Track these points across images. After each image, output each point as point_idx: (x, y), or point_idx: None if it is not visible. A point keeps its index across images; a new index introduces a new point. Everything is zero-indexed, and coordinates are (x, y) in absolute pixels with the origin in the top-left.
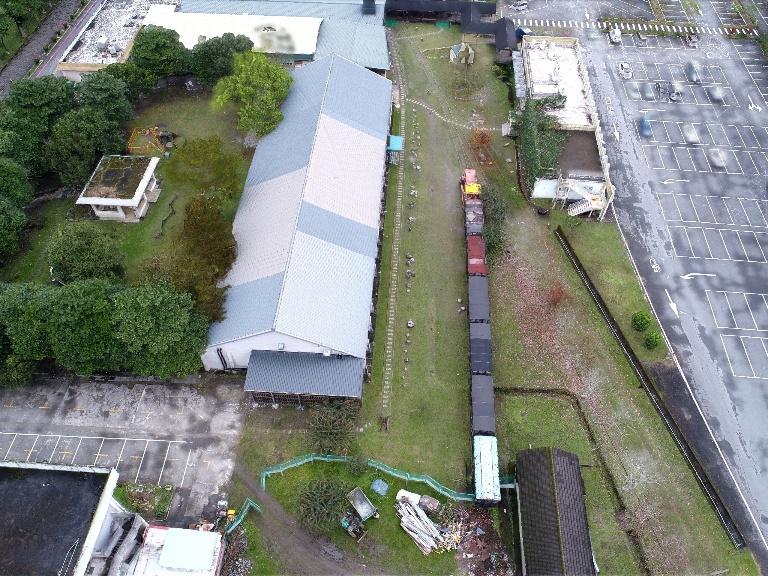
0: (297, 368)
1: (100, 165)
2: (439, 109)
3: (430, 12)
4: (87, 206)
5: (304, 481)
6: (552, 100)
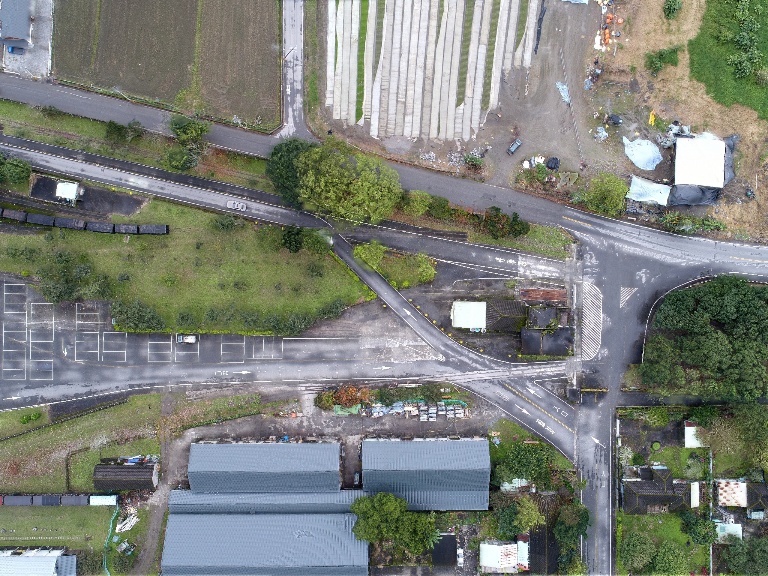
0: None
1: None
2: None
3: None
4: None
5: None
6: None
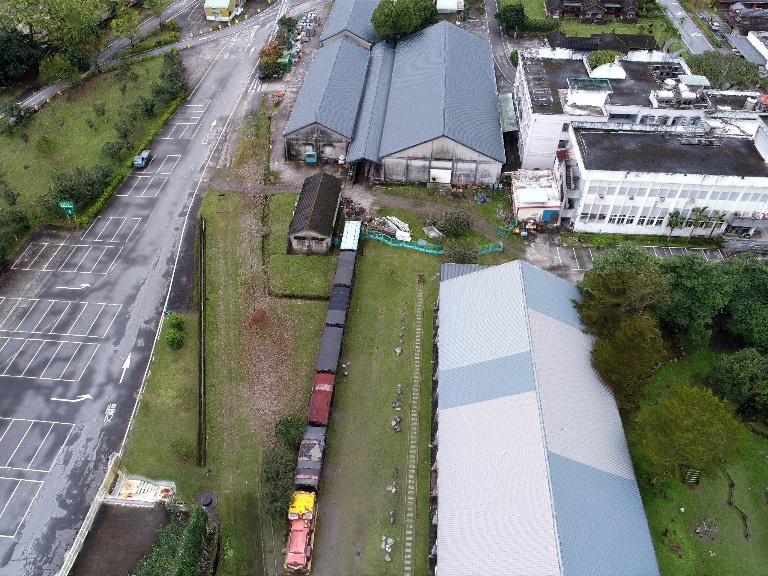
0: None
1: None
2: None
3: None
4: None
5: None
6: None
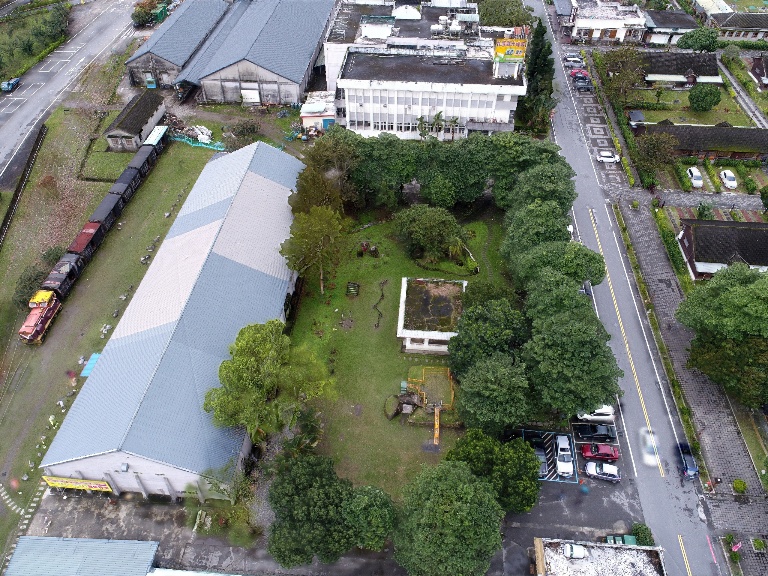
0: None
1: None
2: None
3: None
4: None
5: None
6: None
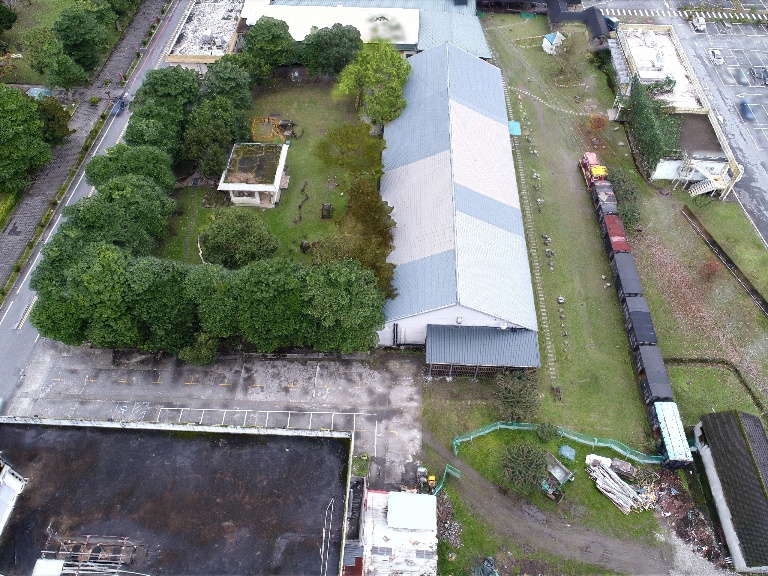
0: (474, 341)
1: (233, 153)
2: (542, 96)
3: (516, 3)
4: (221, 193)
5: (494, 448)
6: (662, 85)
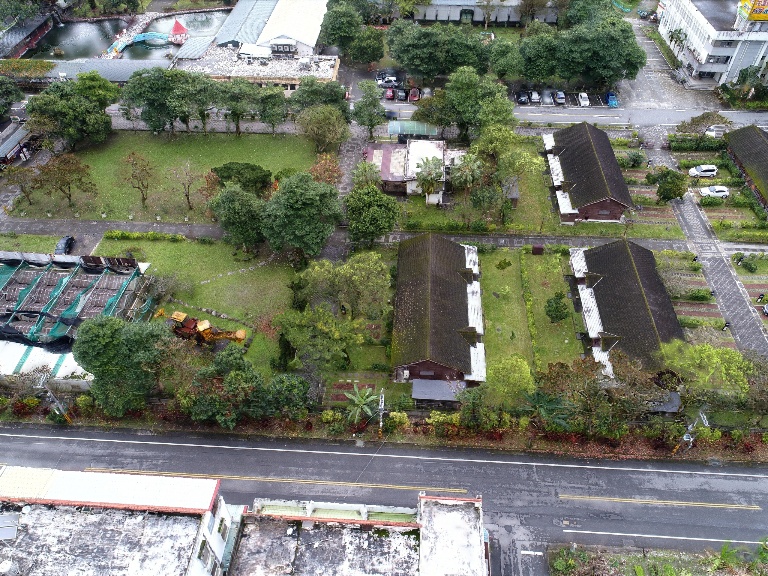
0: None
1: None
2: None
3: None
4: None
5: (623, 4)
6: None
